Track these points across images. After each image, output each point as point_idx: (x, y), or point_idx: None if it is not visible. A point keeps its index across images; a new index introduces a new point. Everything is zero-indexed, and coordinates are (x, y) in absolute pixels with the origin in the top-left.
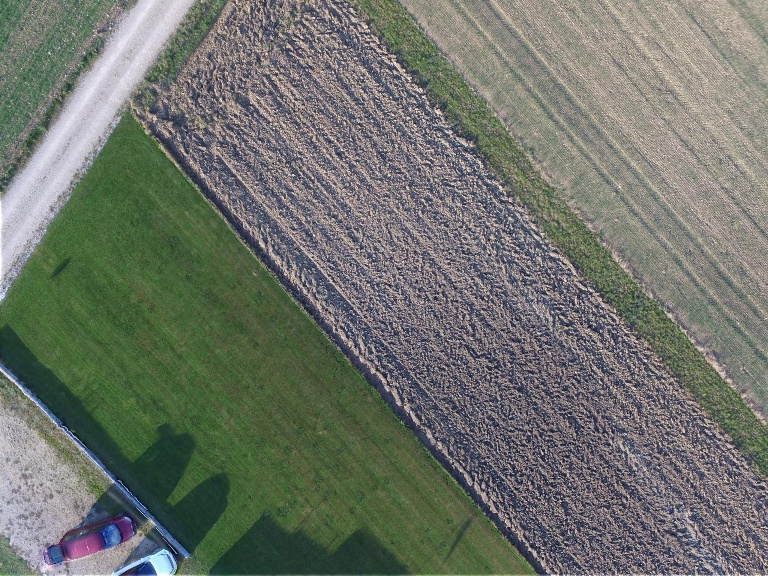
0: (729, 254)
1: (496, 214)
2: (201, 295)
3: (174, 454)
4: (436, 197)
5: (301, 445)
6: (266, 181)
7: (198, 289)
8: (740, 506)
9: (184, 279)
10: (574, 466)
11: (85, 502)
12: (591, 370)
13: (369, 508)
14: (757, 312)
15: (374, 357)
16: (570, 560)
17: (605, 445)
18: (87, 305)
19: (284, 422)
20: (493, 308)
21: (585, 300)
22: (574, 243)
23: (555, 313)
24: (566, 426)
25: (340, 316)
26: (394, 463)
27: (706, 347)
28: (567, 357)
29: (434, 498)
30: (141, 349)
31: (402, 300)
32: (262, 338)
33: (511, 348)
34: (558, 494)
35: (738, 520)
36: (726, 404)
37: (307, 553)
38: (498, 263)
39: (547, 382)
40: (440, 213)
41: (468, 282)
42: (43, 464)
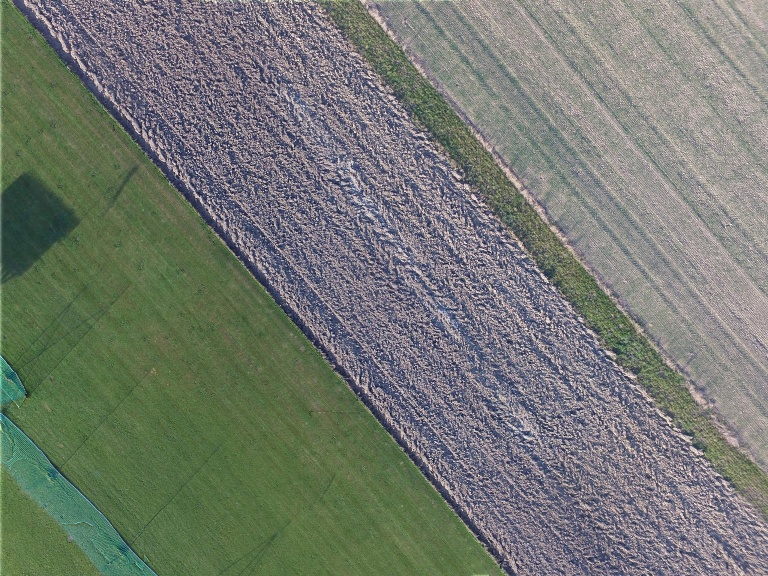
0: None
1: None
2: None
3: None
4: None
5: None
6: None
7: None
8: (400, 155)
9: None
10: (241, 116)
11: None
12: (257, 21)
13: (35, 151)
14: None
15: None
16: (236, 207)
17: (271, 95)
18: None
19: None
20: None
21: None
22: None
23: None
24: (233, 76)
25: None
26: (60, 107)
27: (370, 0)
28: (233, 7)
29: (101, 144)
30: None
31: None
32: None
33: None
34: (225, 143)
35: (398, 170)
36: (388, 56)
37: None
38: None
39: (214, 32)
40: None
41: None
42: None
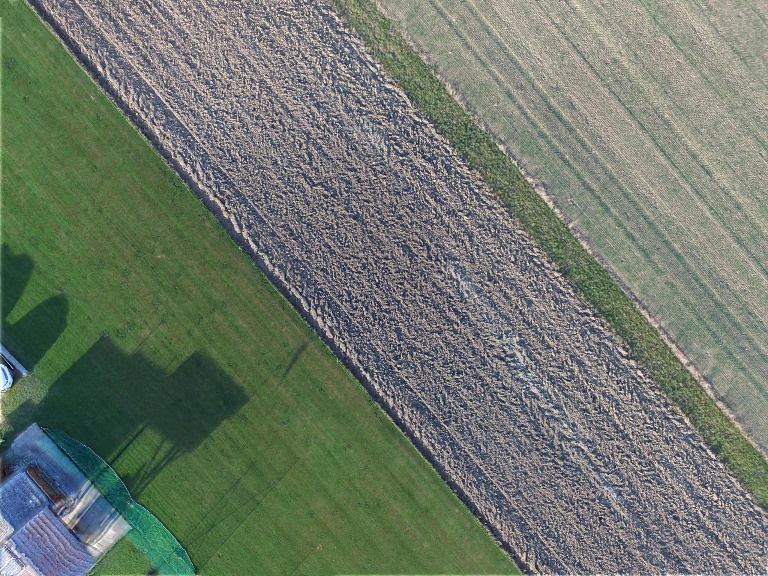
0: (559, 89)
1: (332, 44)
2: (38, 116)
3: (12, 274)
4: (272, 25)
5: (140, 268)
6: (103, 5)
7: (35, 110)
8: (566, 332)
9: (21, 100)
10: (408, 293)
11: None
12: (425, 200)
13: (207, 331)
14: (585, 145)
15: (212, 183)
16: (402, 383)
17: (438, 273)
18: None
19: (122, 245)
20: (329, 137)
21: (419, 131)
22: (409, 75)
23: (390, 143)
24: (400, 254)
25: (178, 141)
26: (232, 287)
27: (536, 179)
28: (401, 187)
29: (271, 322)
30: None
31: (240, 127)
32: (100, 161)
33: (347, 177)
34: (392, 320)
35: (564, 345)
36: (554, 234)
37: (145, 374)
38: (334, 93)
39: (382, 211)
40: (277, 42)
41: (305, 111)
42: None
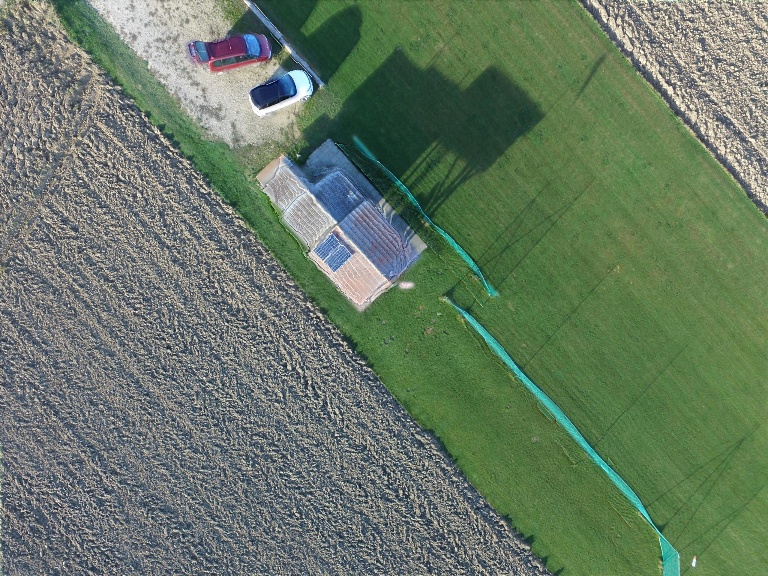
0: None
1: None
2: None
3: None
4: None
5: None
6: None
7: None
8: None
9: None
10: (713, 0)
11: (220, 28)
12: None
13: (502, 43)
14: None
15: None
16: (706, 97)
17: None
18: None
19: None
20: None
21: None
22: None
23: None
24: None
25: None
26: None
27: None
28: None
29: (568, 33)
30: None
31: None
32: None
33: None
34: (695, 30)
35: None
36: None
37: (439, 88)
38: None
39: None
40: None
41: None
42: None
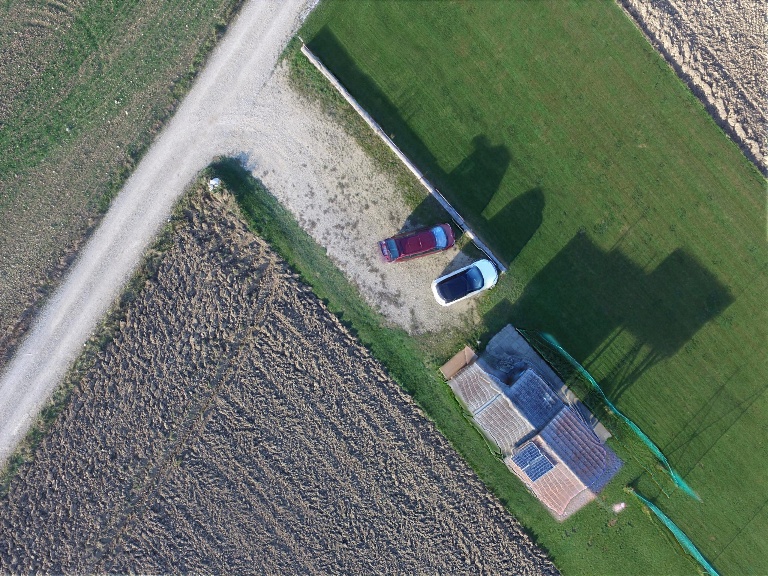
0: None
1: None
2: None
3: (490, 166)
4: None
5: (619, 159)
6: None
7: None
8: None
9: None
10: None
11: (400, 214)
12: None
13: (690, 226)
14: None
15: (699, 65)
16: None
17: None
18: (405, 6)
19: (603, 134)
20: None
21: None
22: None
23: None
24: None
25: (666, 20)
26: (718, 178)
27: None
28: None
29: (759, 216)
30: (459, 53)
31: (731, 3)
32: (583, 43)
33: None
34: None
35: None
36: None
37: (624, 272)
38: None
39: None
40: None
41: None
42: (359, 173)
